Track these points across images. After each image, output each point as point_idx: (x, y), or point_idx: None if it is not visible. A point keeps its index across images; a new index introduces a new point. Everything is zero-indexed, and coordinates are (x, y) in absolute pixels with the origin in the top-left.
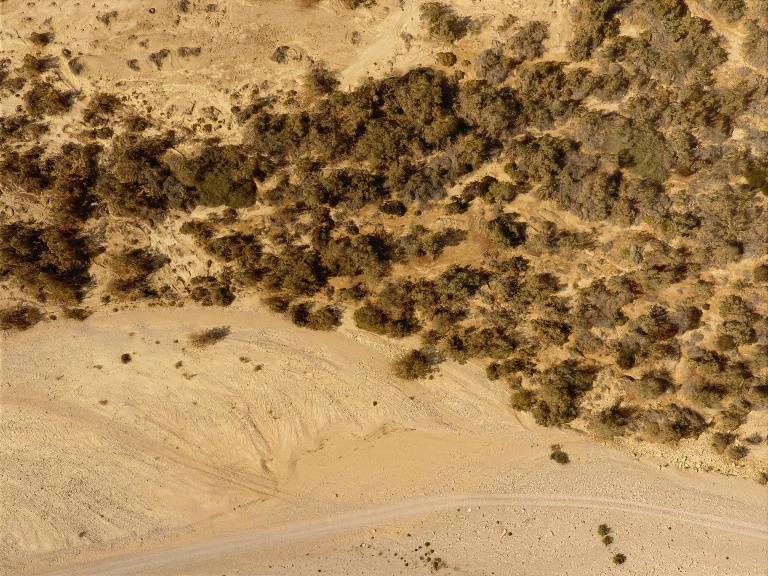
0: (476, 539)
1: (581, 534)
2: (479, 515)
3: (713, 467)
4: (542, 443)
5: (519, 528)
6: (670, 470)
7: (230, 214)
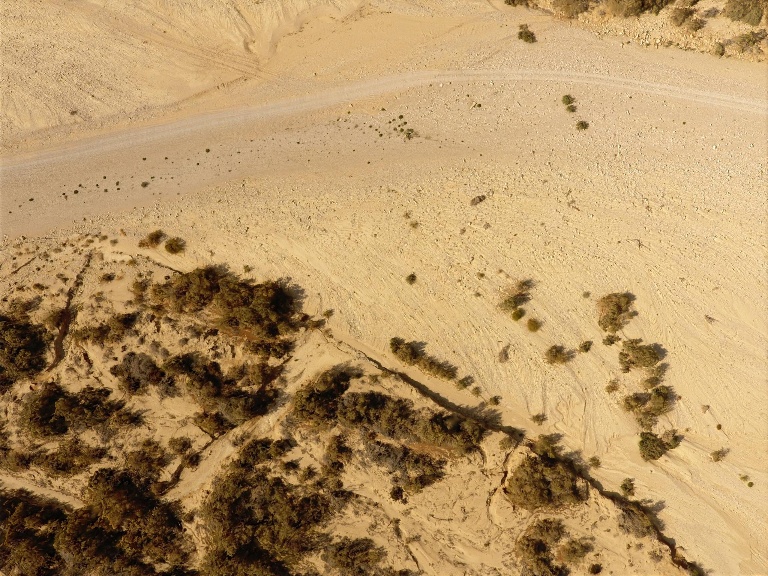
0: (447, 111)
1: (546, 104)
2: (450, 89)
3: (672, 42)
4: (511, 24)
5: (488, 100)
6: (632, 47)
7: None
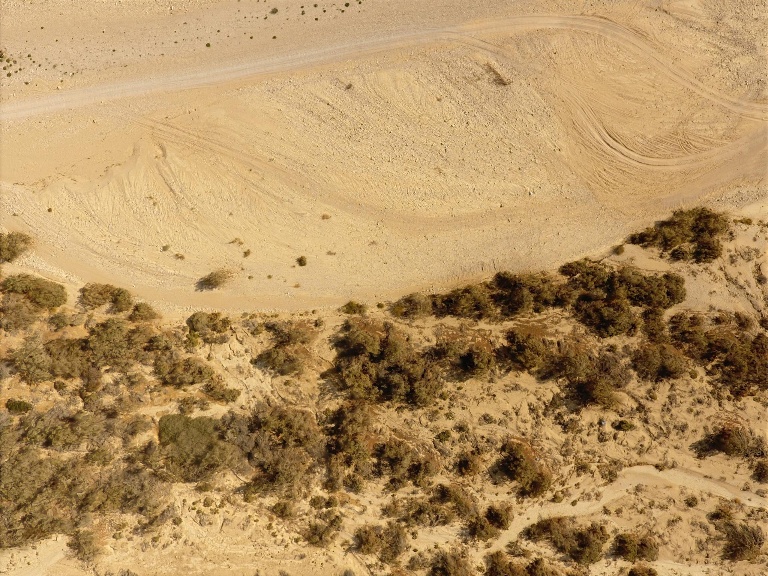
0: None
1: None
2: None
3: None
4: None
5: None
6: None
7: (186, 408)
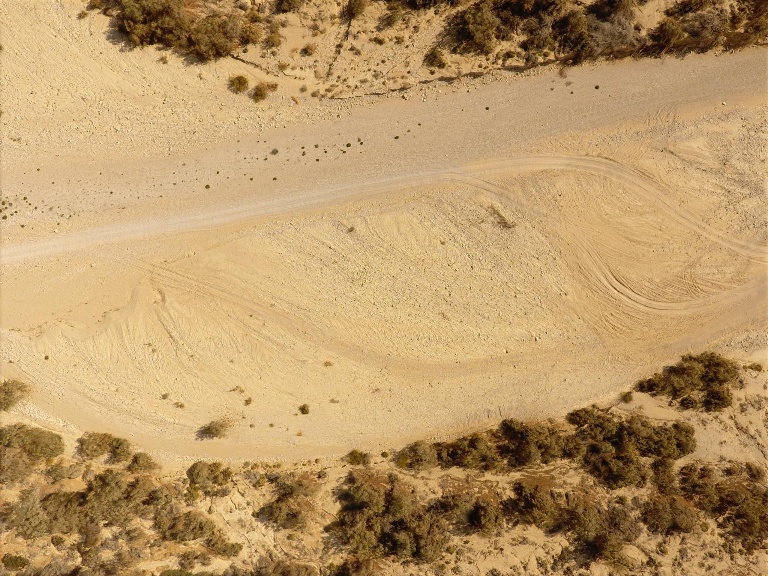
0: None
1: None
2: None
3: None
4: None
5: None
6: None
7: (186, 564)
